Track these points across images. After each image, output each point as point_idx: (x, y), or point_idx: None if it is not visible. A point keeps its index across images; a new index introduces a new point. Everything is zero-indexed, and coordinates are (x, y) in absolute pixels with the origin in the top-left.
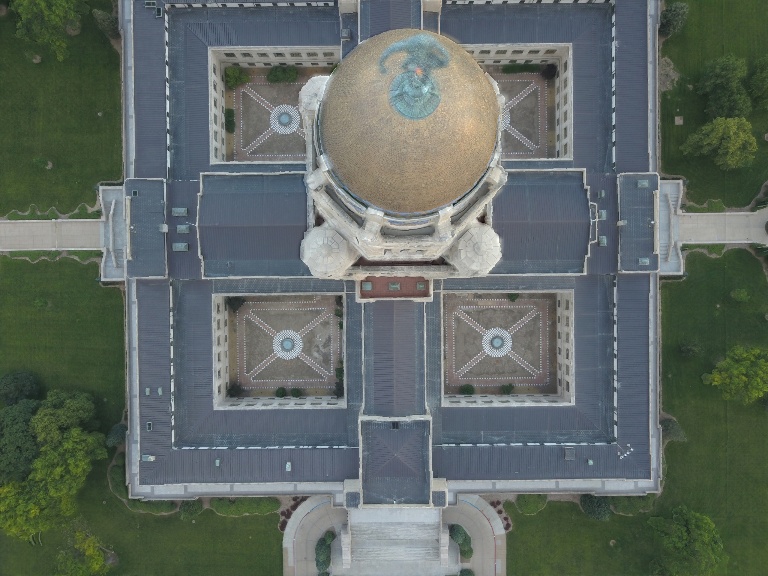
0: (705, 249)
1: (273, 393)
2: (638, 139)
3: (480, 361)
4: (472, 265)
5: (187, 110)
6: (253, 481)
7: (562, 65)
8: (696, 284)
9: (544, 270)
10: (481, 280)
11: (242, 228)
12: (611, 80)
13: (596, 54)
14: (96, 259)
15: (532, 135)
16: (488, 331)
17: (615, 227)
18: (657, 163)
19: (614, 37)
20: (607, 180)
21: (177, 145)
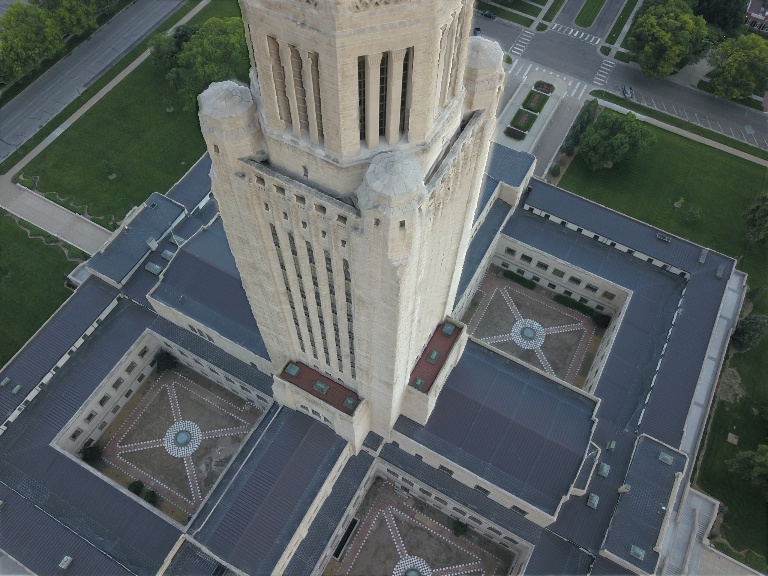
0: None
1: (128, 484)
2: (675, 411)
3: None
4: (373, 183)
5: None
6: (14, 555)
7: (617, 315)
8: None
9: (505, 488)
10: (428, 470)
11: (217, 271)
12: (664, 344)
13: (655, 314)
14: (81, 261)
15: (560, 369)
16: (409, 556)
17: (615, 493)
18: (693, 463)
19: (679, 305)
20: (624, 436)
21: None
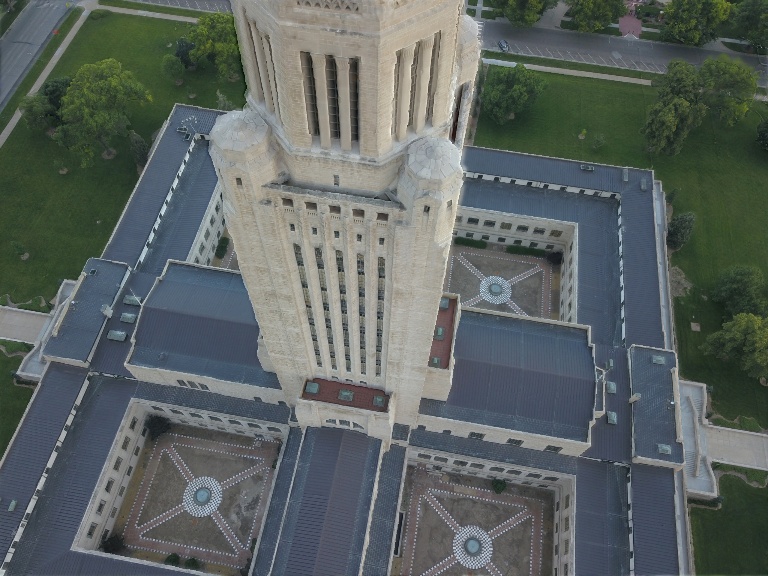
0: (742, 474)
1: (162, 561)
2: (650, 317)
3: (447, 569)
4: (421, 171)
5: (181, 217)
6: None
7: (568, 249)
8: (736, 518)
9: (537, 432)
10: (459, 441)
11: (191, 317)
12: (618, 262)
13: (602, 237)
14: (24, 354)
15: (534, 313)
16: (462, 528)
17: (627, 405)
18: None
19: (620, 223)
20: (616, 353)
21: (158, 245)
